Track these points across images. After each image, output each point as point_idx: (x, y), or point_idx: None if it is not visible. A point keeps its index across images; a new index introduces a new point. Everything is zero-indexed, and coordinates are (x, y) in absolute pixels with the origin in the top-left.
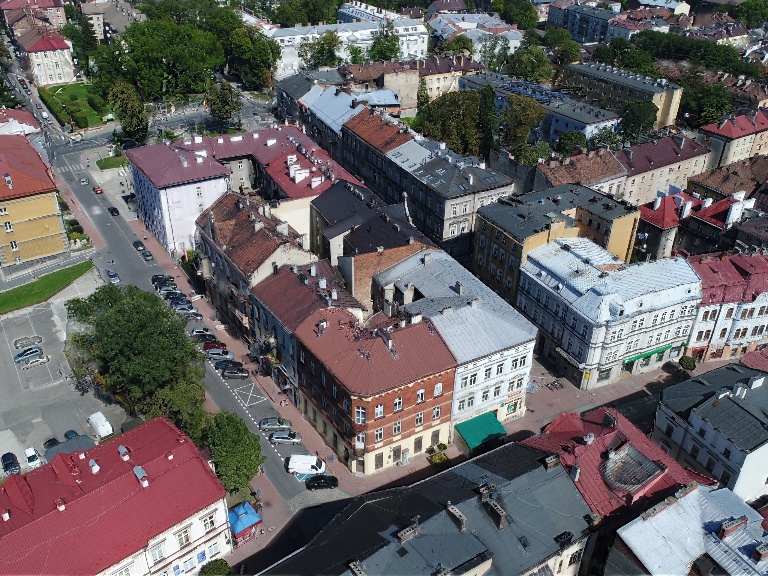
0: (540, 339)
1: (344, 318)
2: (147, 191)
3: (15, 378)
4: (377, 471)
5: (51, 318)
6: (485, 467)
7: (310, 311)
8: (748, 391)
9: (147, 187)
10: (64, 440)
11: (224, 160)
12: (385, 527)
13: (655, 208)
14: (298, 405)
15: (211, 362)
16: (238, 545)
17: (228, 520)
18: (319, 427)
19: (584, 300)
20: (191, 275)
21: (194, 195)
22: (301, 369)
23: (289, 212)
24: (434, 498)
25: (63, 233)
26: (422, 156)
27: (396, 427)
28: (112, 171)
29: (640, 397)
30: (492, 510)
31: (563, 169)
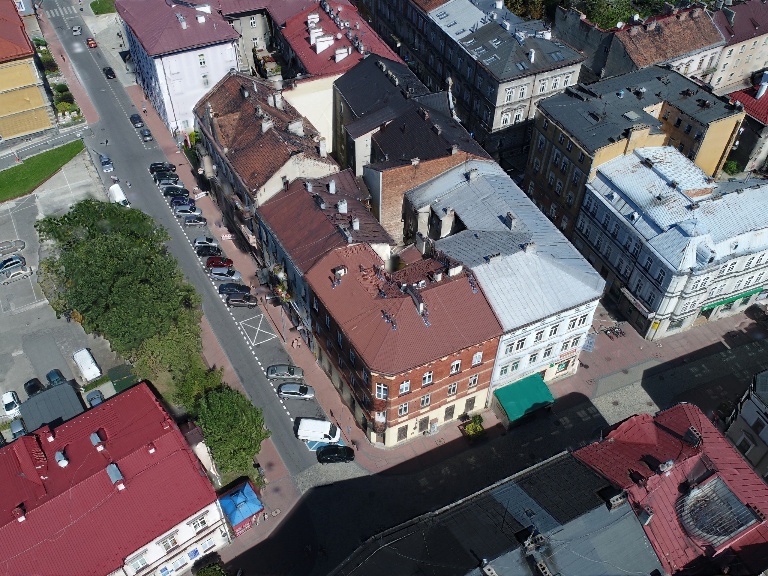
0: (602, 271)
1: (366, 261)
2: (142, 55)
3: None
4: (400, 442)
5: (36, 216)
6: (531, 493)
7: (326, 248)
8: None
9: (141, 51)
10: (46, 383)
11: (233, 16)
12: None
13: (758, 96)
14: (312, 349)
15: (215, 283)
16: (237, 534)
17: (223, 517)
18: (335, 381)
19: (665, 239)
20: (194, 165)
21: (196, 64)
22: (314, 316)
23: (307, 95)
24: (466, 541)
25: (47, 106)
26: (473, 19)
27: (424, 399)
28: (108, 17)
29: (716, 352)
30: (538, 571)
31: (646, 37)
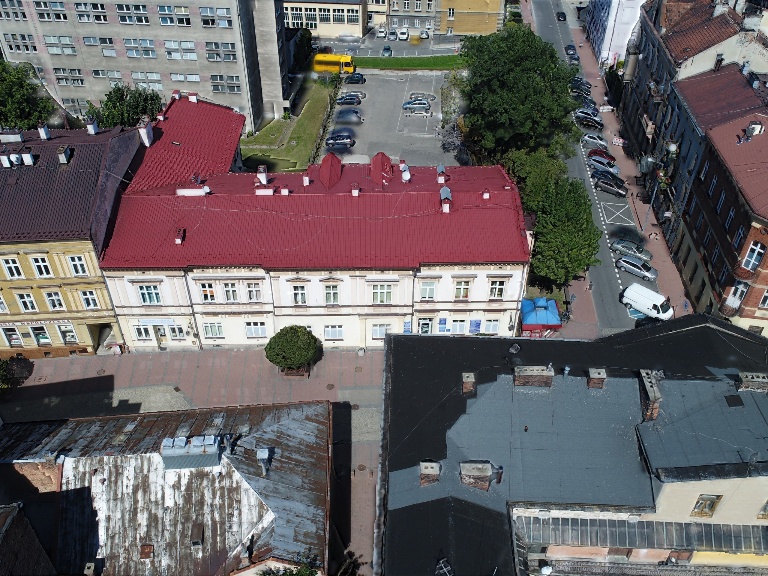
0: None
1: None
2: None
3: (396, 120)
4: None
5: None
6: None
7: None
8: None
9: None
10: None
11: None
12: (722, 364)
13: None
14: (671, 242)
15: (589, 169)
16: None
17: (520, 299)
18: (686, 272)
19: None
20: (612, 85)
21: None
22: (695, 188)
23: None
24: None
25: (501, 14)
26: None
27: None
28: None
29: None
30: None
31: None
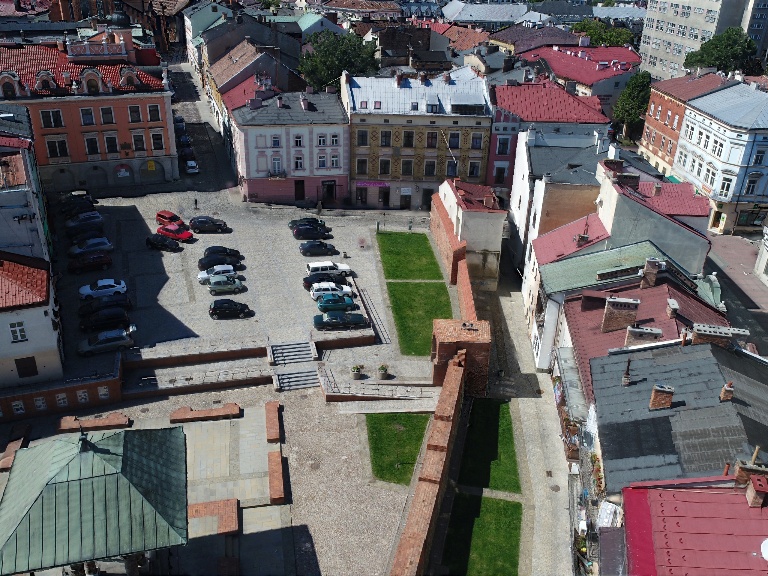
0: None
1: None
2: None
3: None
4: None
5: None
6: None
7: None
8: None
9: None
10: None
11: None
12: None
13: None
14: None
15: None
16: None
17: None
18: None
19: None
20: None
21: None
22: None
23: None
24: None
25: None
26: None
27: None
28: None
29: (742, 299)
30: None
31: None
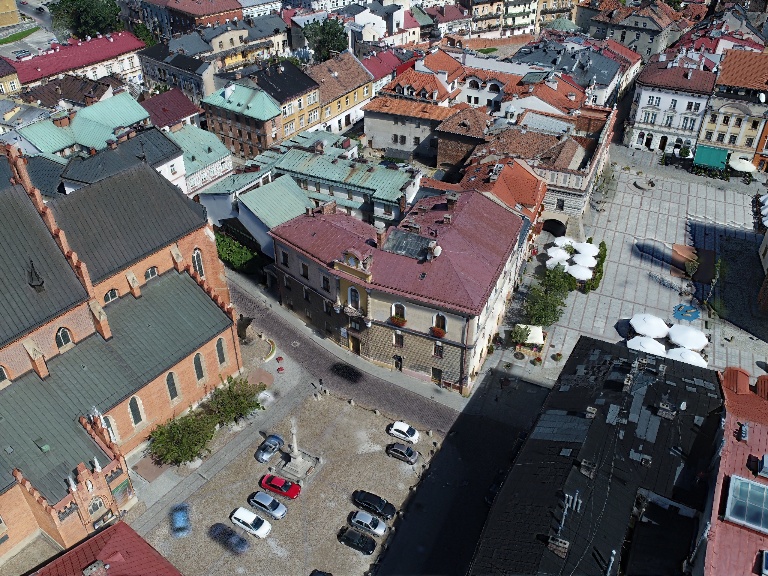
0: None
1: None
2: None
3: None
4: None
5: (27, 45)
6: None
7: None
8: (366, 4)
9: None
10: None
11: None
12: None
13: None
14: None
15: None
16: None
17: None
18: None
19: None
20: None
21: None
22: (172, 26)
23: None
24: None
25: (17, 11)
26: None
27: None
28: None
29: None
30: (248, 21)
31: None
